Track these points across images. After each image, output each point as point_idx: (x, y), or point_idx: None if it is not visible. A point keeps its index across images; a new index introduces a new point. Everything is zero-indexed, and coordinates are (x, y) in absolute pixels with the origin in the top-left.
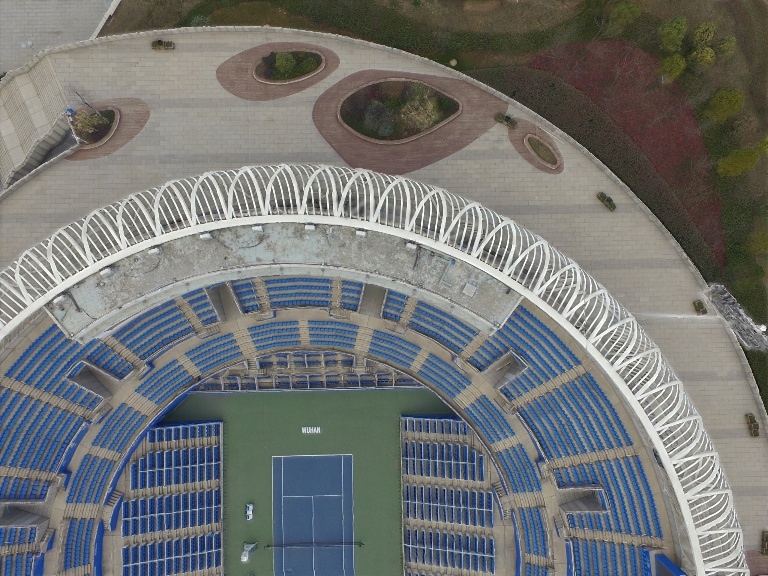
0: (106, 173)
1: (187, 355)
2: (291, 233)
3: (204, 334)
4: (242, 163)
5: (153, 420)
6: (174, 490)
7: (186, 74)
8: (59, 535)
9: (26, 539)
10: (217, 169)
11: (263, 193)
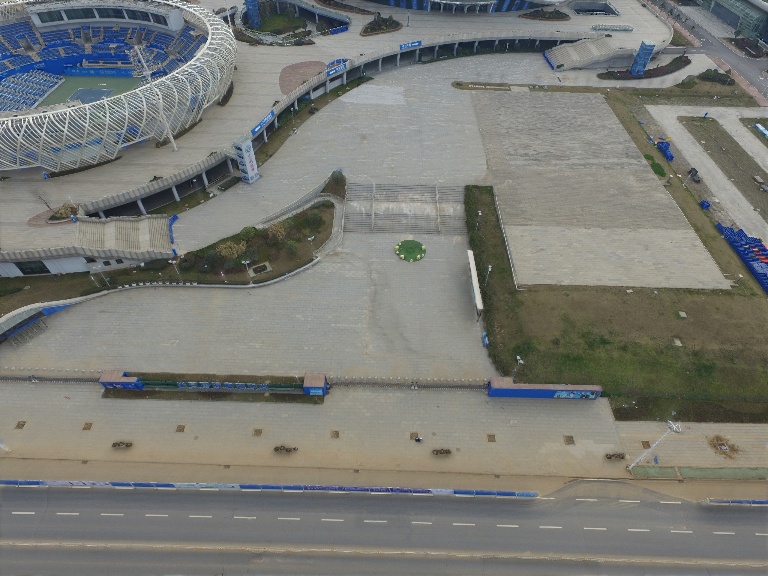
0: None
1: None
2: None
3: None
4: None
5: None
6: None
7: None
8: None
9: None
10: (6, 197)
11: None
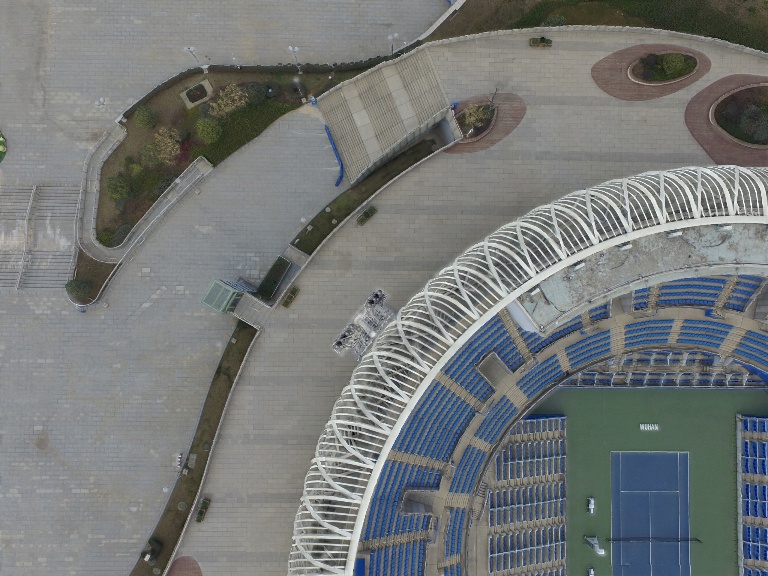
0: (483, 167)
1: (565, 350)
2: (752, 234)
3: (589, 329)
4: (616, 162)
5: None
6: (526, 482)
7: (562, 72)
8: (441, 523)
9: (419, 526)
10: (592, 167)
11: (730, 194)
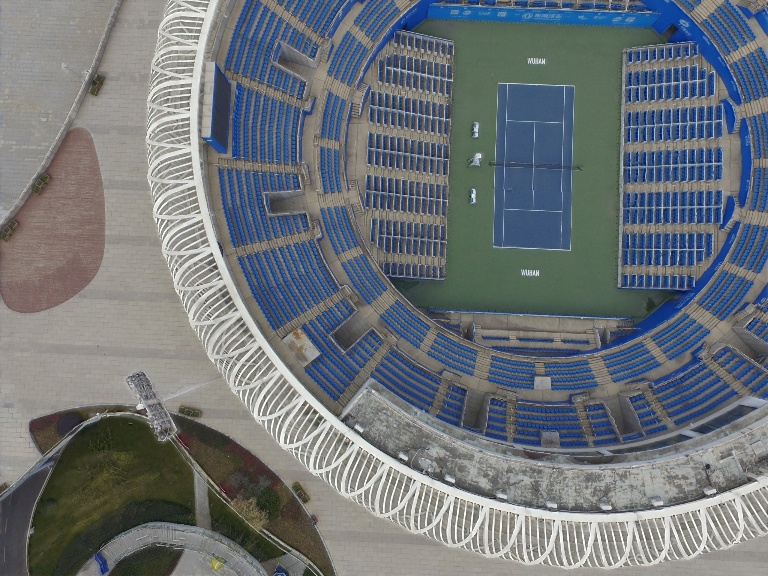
0: None
1: None
2: None
3: None
4: None
5: (407, 12)
6: (410, 97)
7: None
8: (319, 103)
9: (295, 94)
10: None
11: None
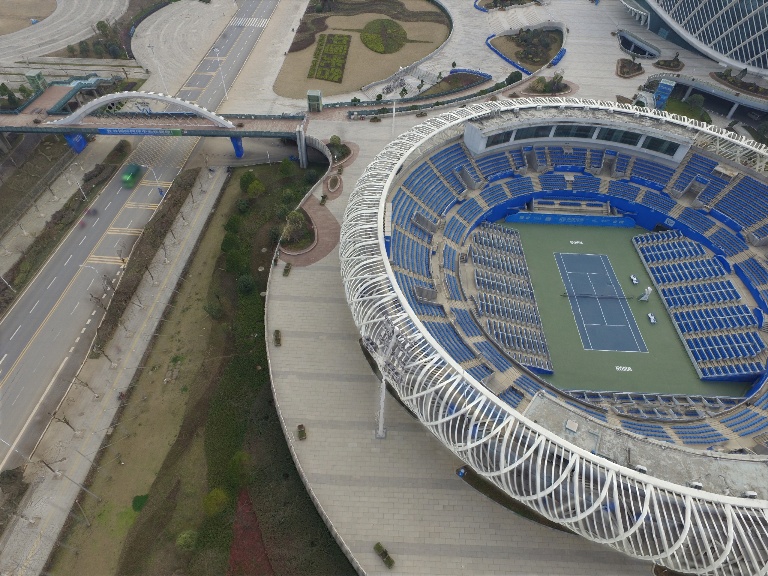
0: None
1: None
2: (764, 492)
3: None
4: None
5: None
6: (719, 333)
7: None
8: None
9: None
10: None
11: None
